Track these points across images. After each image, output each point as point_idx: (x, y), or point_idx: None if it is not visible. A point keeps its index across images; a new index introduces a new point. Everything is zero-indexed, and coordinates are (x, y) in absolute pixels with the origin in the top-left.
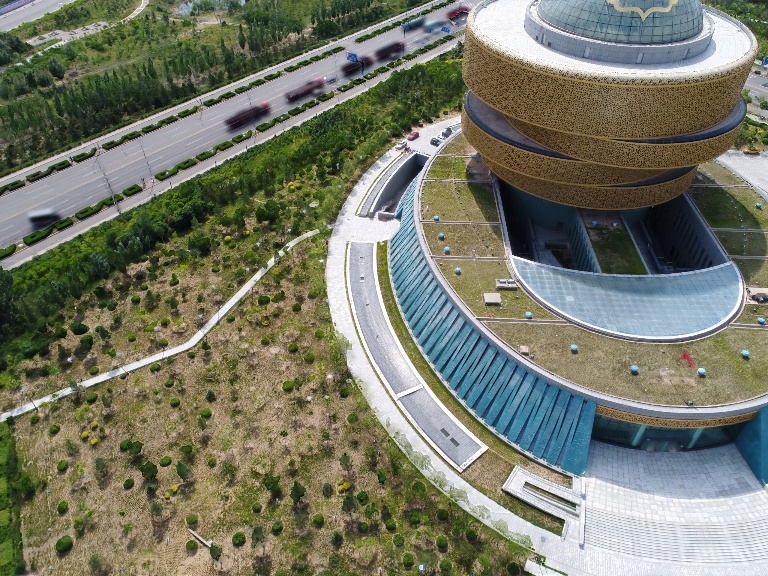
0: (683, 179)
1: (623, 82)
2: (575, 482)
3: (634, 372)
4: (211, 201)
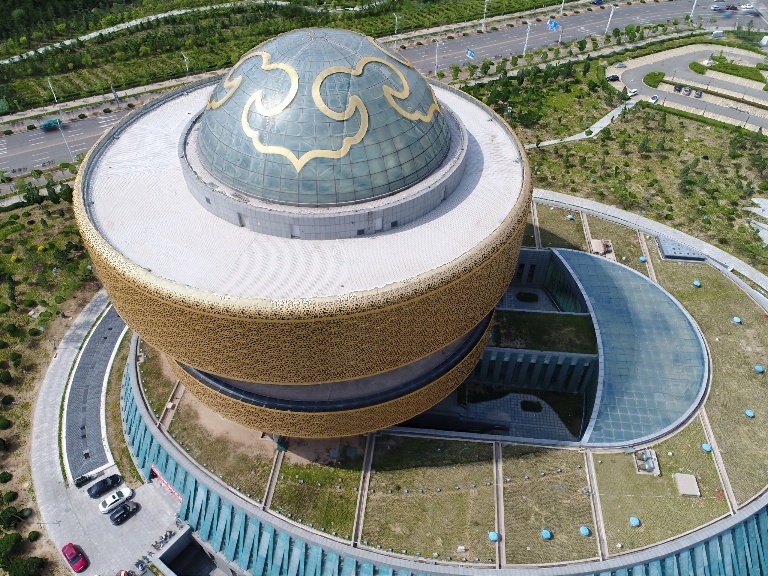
0: None
1: None
2: None
3: None
4: None
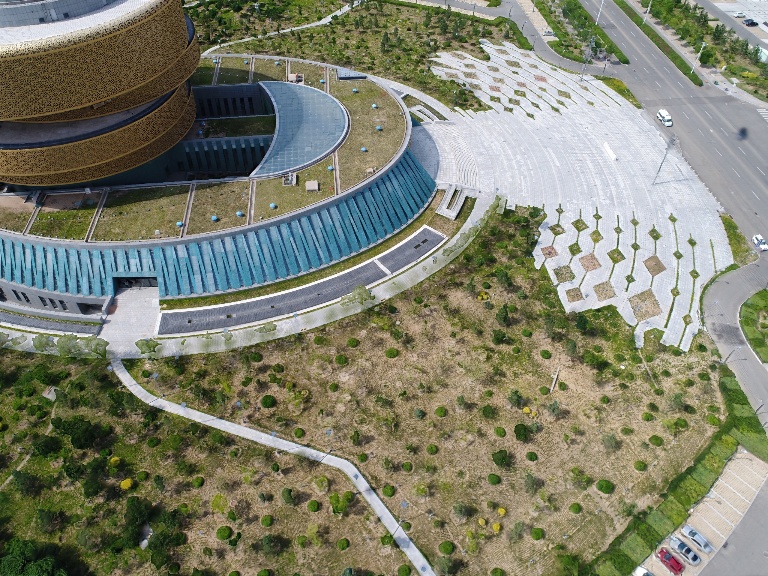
0: None
1: None
2: (441, 188)
3: (380, 129)
4: (5, 544)
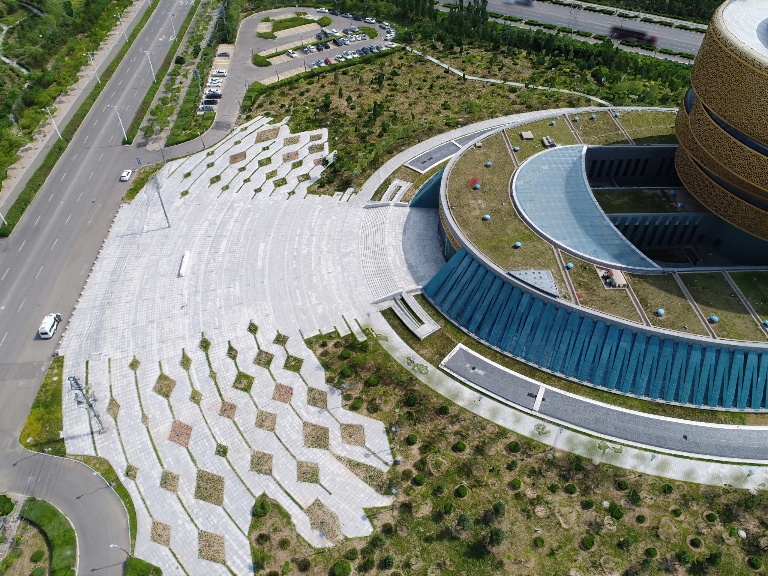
0: (764, 217)
1: (722, 39)
2: None
3: None
4: None
